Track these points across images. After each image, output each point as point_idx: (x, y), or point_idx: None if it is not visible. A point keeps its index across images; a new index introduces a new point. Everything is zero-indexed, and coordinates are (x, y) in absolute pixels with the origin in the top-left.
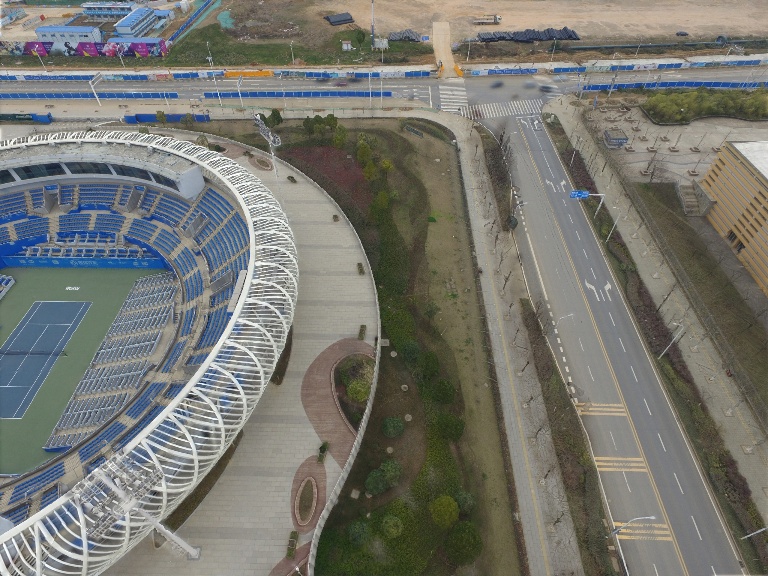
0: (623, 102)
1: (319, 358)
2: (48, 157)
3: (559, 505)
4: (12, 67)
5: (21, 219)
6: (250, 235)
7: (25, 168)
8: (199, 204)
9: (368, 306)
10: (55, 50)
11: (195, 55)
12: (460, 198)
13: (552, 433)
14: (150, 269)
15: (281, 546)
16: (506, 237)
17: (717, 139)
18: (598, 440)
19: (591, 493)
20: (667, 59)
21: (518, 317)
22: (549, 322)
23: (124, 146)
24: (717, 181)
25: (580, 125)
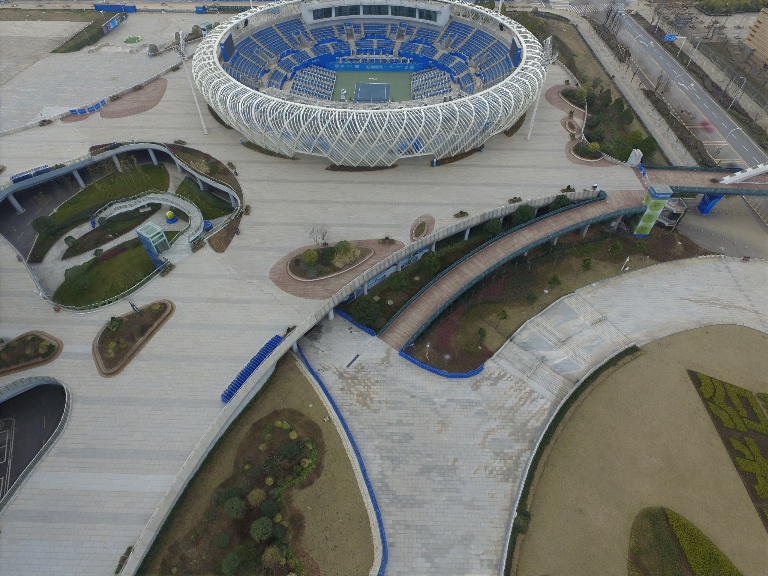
0: (683, 3)
1: (549, 91)
2: (354, 1)
3: None
4: None
5: (332, 42)
6: (508, 26)
7: (340, 8)
8: (447, 30)
9: (564, 75)
10: None
11: None
12: (587, 48)
13: (675, 132)
14: None
15: (567, 137)
16: (623, 64)
17: (752, 22)
18: (700, 135)
19: (701, 147)
20: None
21: (642, 95)
22: (661, 97)
23: None
24: (756, 36)
25: None
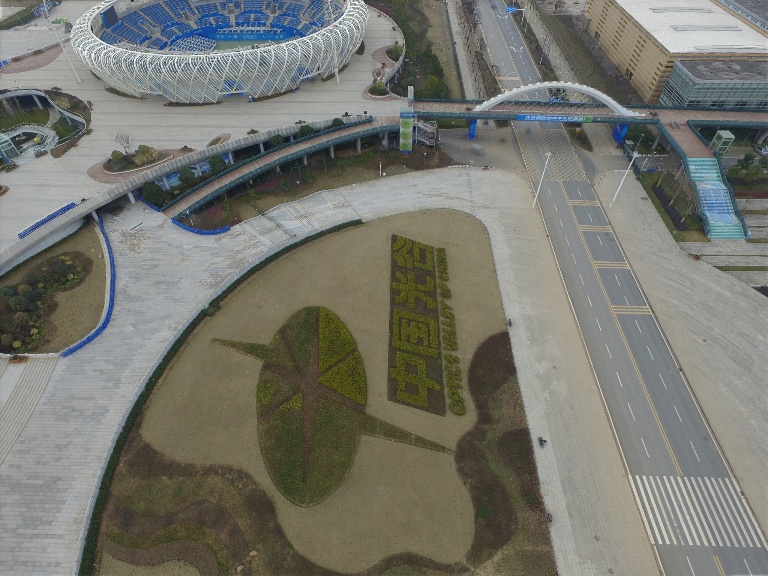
0: None
1: (378, 50)
2: None
3: None
4: None
5: (215, 16)
6: None
7: None
8: (310, 4)
9: (399, 38)
10: None
11: None
12: (446, 21)
13: (484, 83)
14: None
15: (371, 82)
16: (471, 33)
17: None
18: (504, 85)
19: (497, 93)
20: None
21: (473, 56)
22: (489, 58)
23: None
24: (591, 8)
25: None
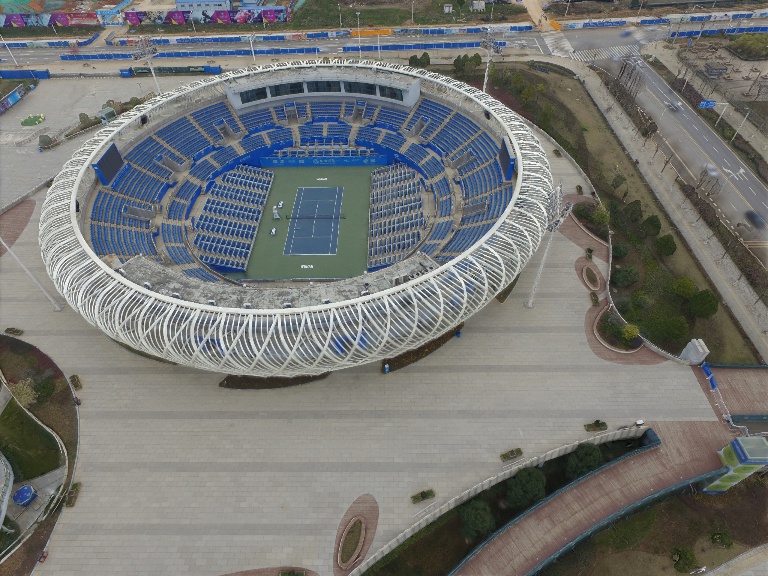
0: (711, 44)
1: None
2: (295, 77)
3: (752, 296)
4: (157, 34)
5: (269, 129)
6: (496, 116)
7: (276, 87)
8: (417, 111)
9: (575, 175)
10: (193, 18)
11: (316, 20)
12: (599, 116)
13: (732, 258)
14: (375, 166)
15: (586, 300)
16: (648, 140)
17: None
18: (767, 261)
19: None
20: (736, 12)
21: (678, 191)
22: (703, 194)
23: (350, 69)
24: None
25: (678, 63)
